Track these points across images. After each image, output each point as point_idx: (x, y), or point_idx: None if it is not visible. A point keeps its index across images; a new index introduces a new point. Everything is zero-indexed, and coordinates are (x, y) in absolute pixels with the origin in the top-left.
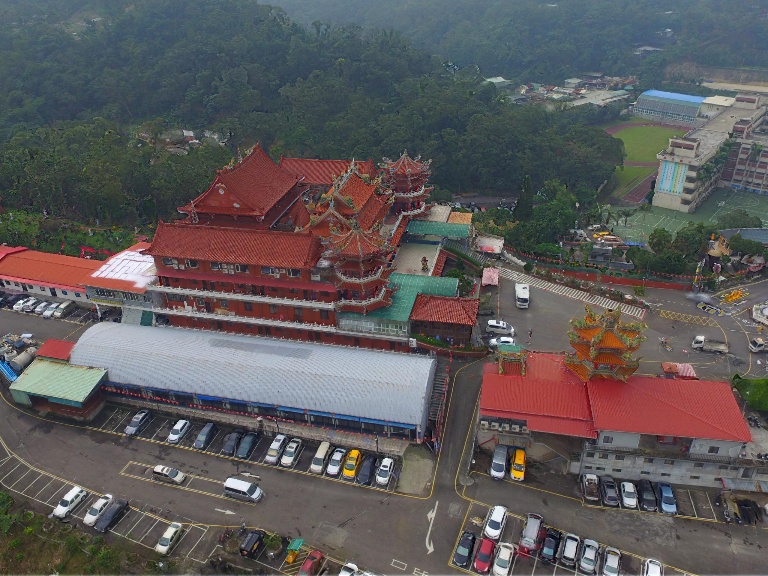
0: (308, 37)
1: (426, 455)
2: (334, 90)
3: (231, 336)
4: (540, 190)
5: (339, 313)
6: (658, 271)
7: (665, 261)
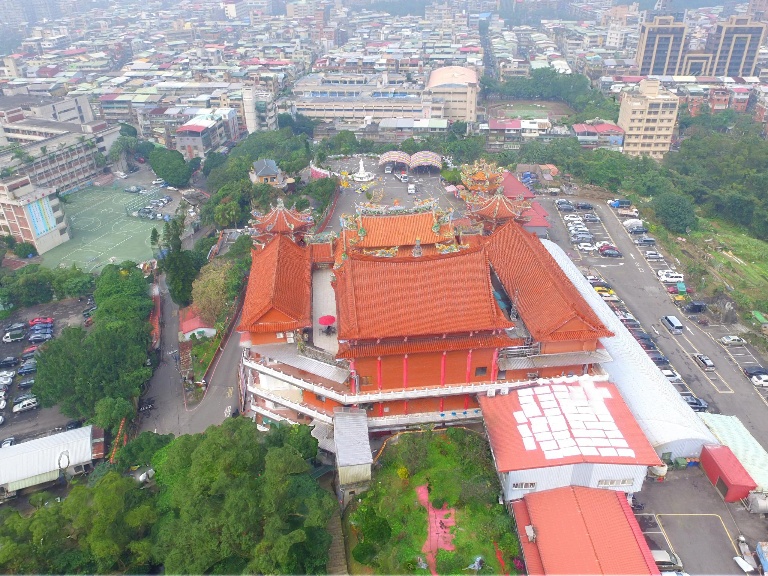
0: None
1: None
2: None
3: None
4: (0, 302)
5: None
6: None
7: (333, 183)
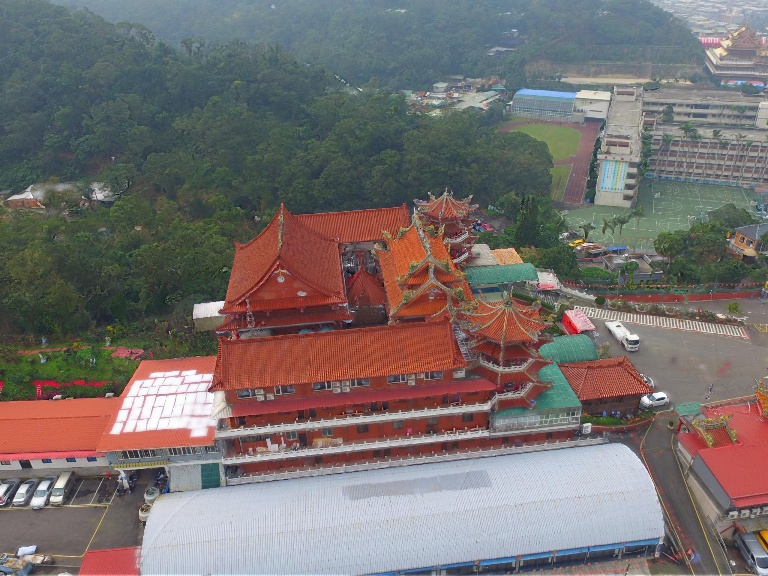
0: (180, 58)
1: (676, 571)
2: (243, 118)
3: (360, 475)
4: None
5: (496, 413)
6: (726, 282)
7: (734, 271)
